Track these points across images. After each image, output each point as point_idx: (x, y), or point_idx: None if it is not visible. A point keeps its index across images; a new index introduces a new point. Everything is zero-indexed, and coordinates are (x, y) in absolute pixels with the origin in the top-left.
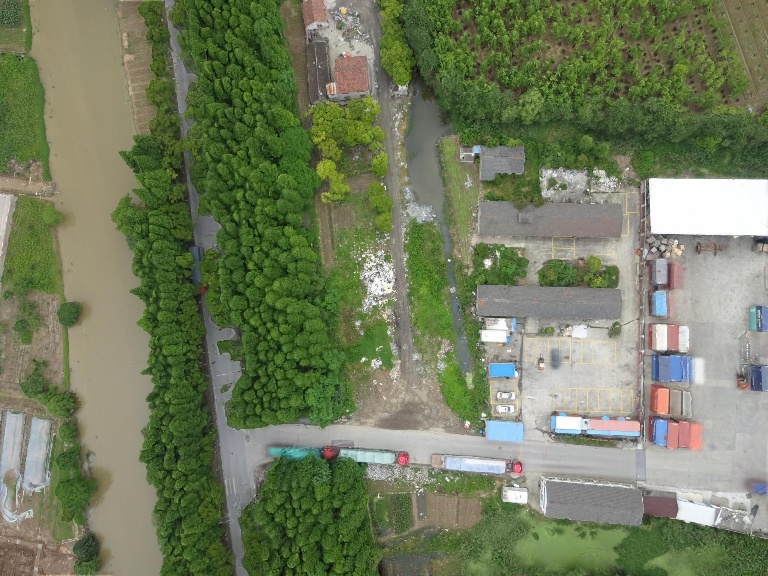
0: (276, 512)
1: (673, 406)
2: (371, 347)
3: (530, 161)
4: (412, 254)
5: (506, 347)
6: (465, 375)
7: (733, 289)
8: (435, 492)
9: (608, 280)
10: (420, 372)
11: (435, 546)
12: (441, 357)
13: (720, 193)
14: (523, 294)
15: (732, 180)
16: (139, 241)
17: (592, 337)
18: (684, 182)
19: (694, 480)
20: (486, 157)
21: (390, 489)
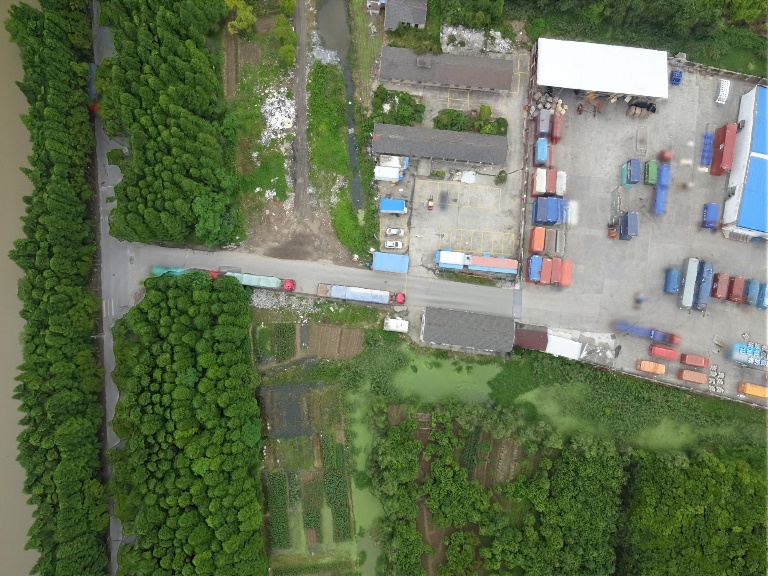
0: (150, 308)
1: (548, 243)
2: (266, 177)
3: (433, 17)
4: (314, 92)
5: (398, 187)
6: (357, 212)
7: (608, 148)
8: (319, 322)
9: (497, 130)
10: (313, 205)
11: (315, 375)
12: (335, 191)
13: (600, 56)
14: (417, 133)
15: (611, 46)
16: (32, 36)
17: (480, 183)
18: (569, 43)
19: (565, 320)
20: (391, 4)
21: (274, 318)
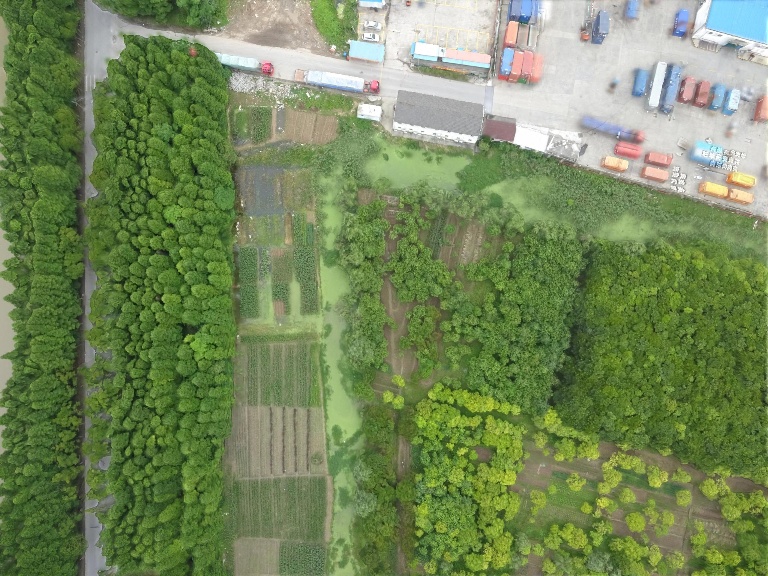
0: (128, 60)
1: (521, 37)
2: None
3: None
4: None
5: None
6: (337, 5)
7: None
8: (295, 107)
9: None
10: None
11: (289, 157)
12: None
13: None
14: None
15: None
16: None
17: None
18: None
19: (534, 117)
20: None
21: (252, 102)
